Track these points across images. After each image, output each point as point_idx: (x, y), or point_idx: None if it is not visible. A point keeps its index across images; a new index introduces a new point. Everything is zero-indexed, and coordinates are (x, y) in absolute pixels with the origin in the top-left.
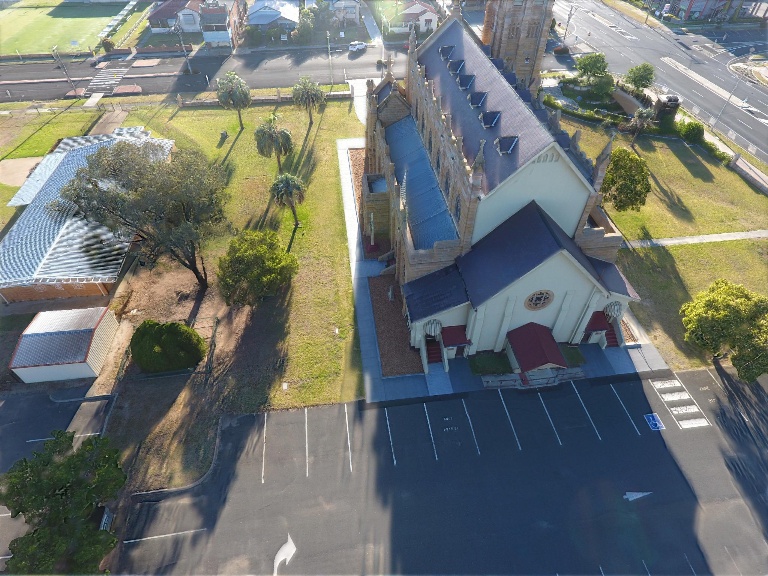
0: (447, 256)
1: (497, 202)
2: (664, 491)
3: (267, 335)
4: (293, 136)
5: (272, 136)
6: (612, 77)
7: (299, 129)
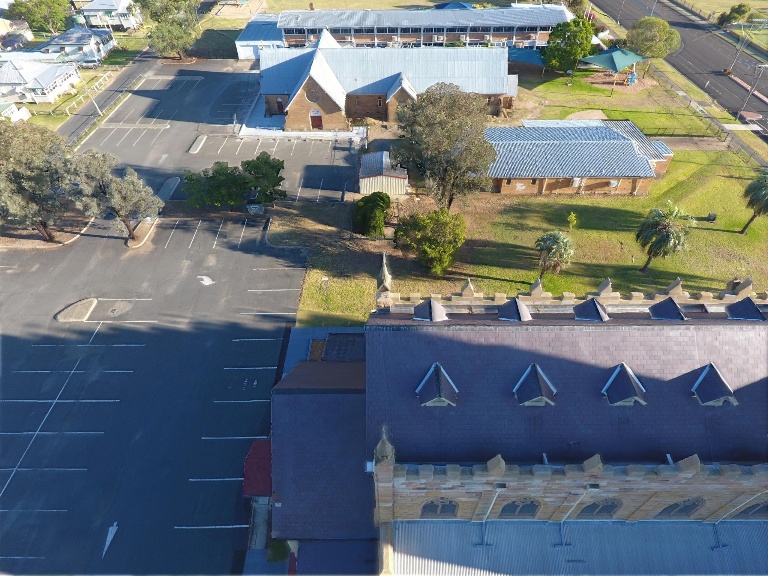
0: None
1: None
2: (96, 573)
3: (379, 267)
4: None
5: (658, 226)
6: None
7: None
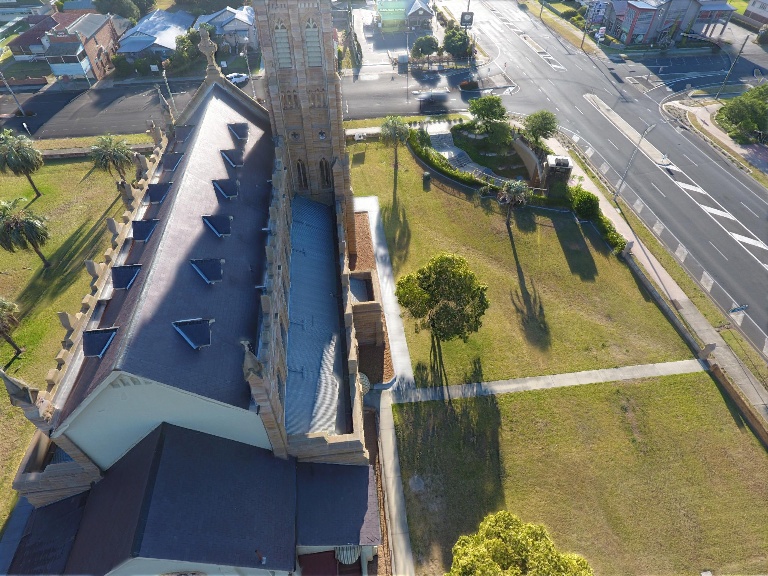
0: (75, 481)
1: (98, 429)
2: None
3: None
4: (94, 207)
5: (11, 226)
6: (508, 125)
7: (107, 196)
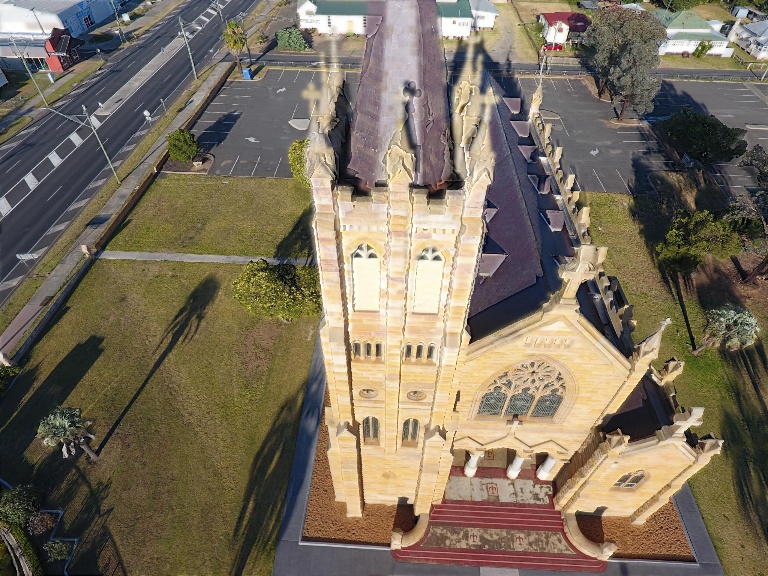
0: None
1: None
2: None
3: (657, 235)
4: None
5: None
6: None
7: None
